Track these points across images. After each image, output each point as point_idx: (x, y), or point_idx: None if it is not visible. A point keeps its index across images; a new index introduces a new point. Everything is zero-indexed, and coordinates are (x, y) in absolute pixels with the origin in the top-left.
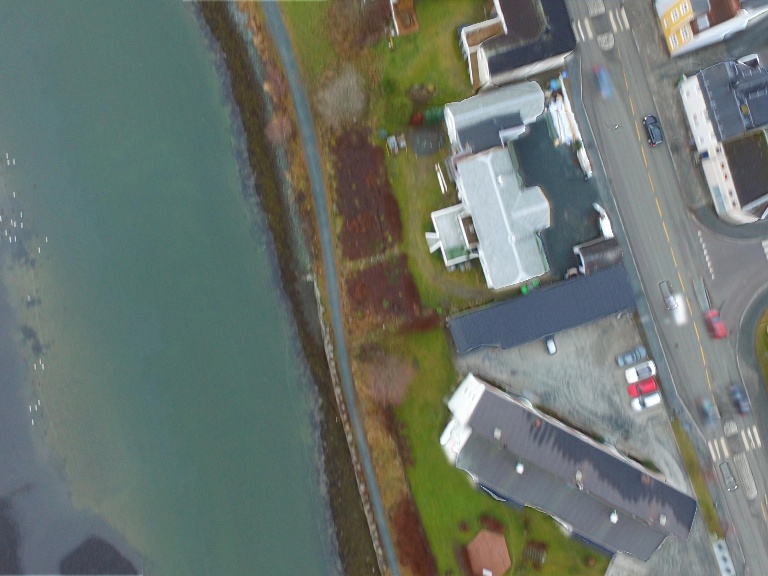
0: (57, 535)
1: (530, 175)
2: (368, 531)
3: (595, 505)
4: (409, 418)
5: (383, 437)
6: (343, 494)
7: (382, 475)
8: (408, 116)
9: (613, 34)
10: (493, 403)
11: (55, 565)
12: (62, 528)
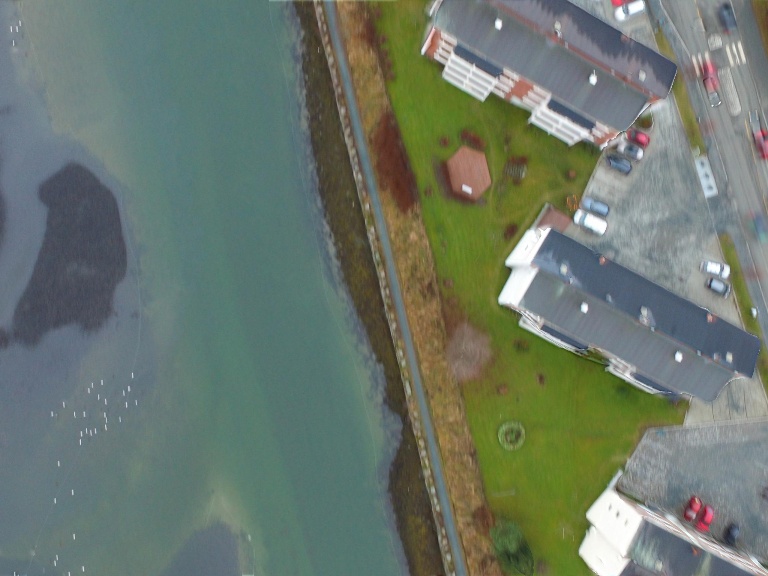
0: (36, 159)
1: None
2: (348, 161)
3: (574, 65)
4: (390, 30)
5: (364, 54)
6: (324, 127)
7: (363, 96)
8: None
9: None
10: None
11: (34, 189)
12: (41, 152)
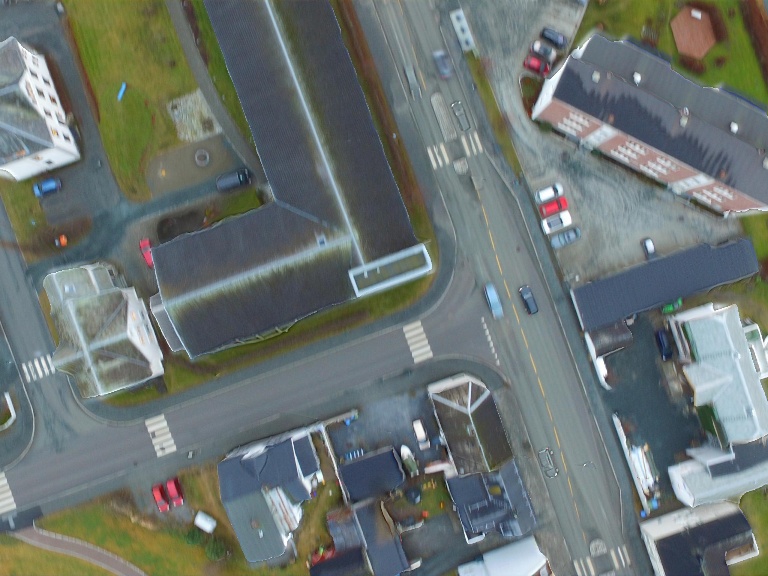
0: None
1: (672, 415)
2: None
3: (658, 91)
4: None
5: None
6: None
7: None
8: None
9: (591, 555)
10: (766, 193)
11: None
12: None
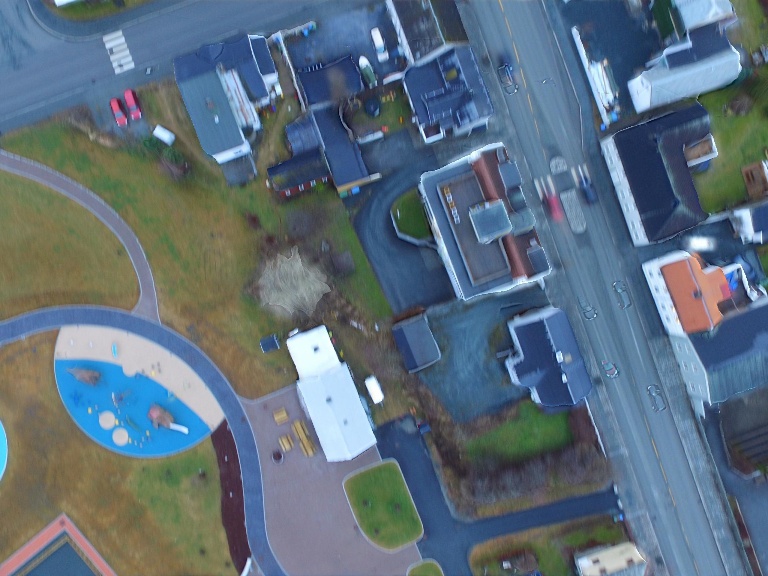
0: None
1: (631, 30)
2: None
3: None
4: None
5: None
6: None
7: None
8: (761, 75)
9: (552, 173)
10: None
11: None
12: None
